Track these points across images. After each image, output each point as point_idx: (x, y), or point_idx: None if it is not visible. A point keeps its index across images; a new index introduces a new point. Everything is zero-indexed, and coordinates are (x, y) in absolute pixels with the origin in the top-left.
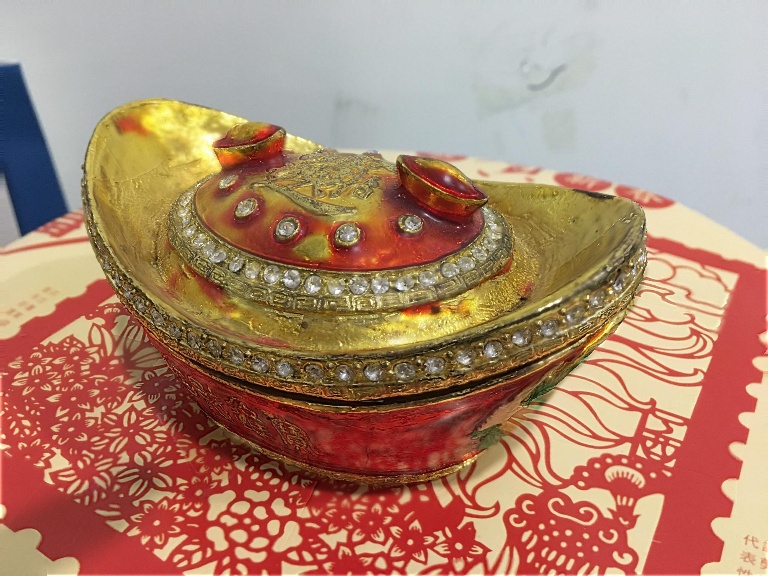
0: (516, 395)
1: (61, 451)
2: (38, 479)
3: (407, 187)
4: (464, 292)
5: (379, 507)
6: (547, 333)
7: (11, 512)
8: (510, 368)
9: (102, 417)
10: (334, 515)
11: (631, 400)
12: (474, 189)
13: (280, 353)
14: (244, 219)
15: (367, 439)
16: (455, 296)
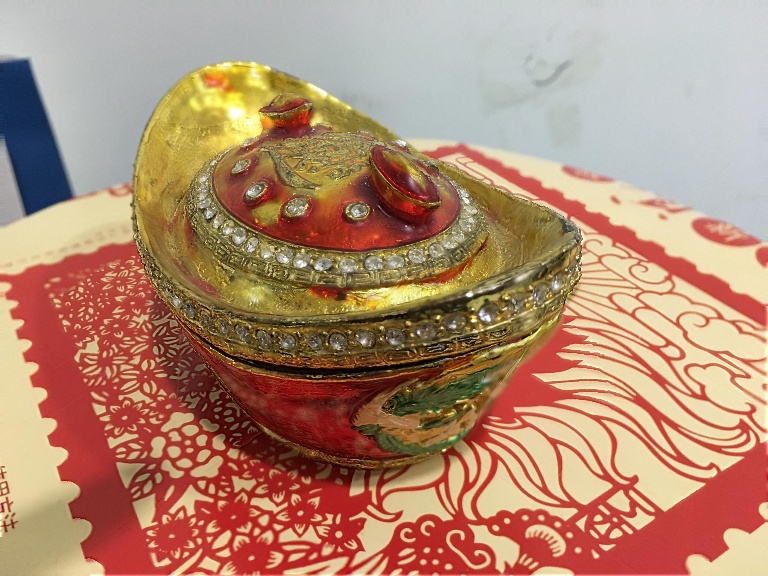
0: (373, 398)
1: (99, 340)
2: (71, 355)
3: (373, 176)
4: (377, 288)
5: (296, 473)
6: (394, 342)
7: (40, 372)
8: (358, 367)
9: (143, 324)
10: (255, 465)
11: (611, 469)
12: (427, 191)
13: (186, 294)
14: (234, 176)
15: (258, 398)
16: (366, 289)
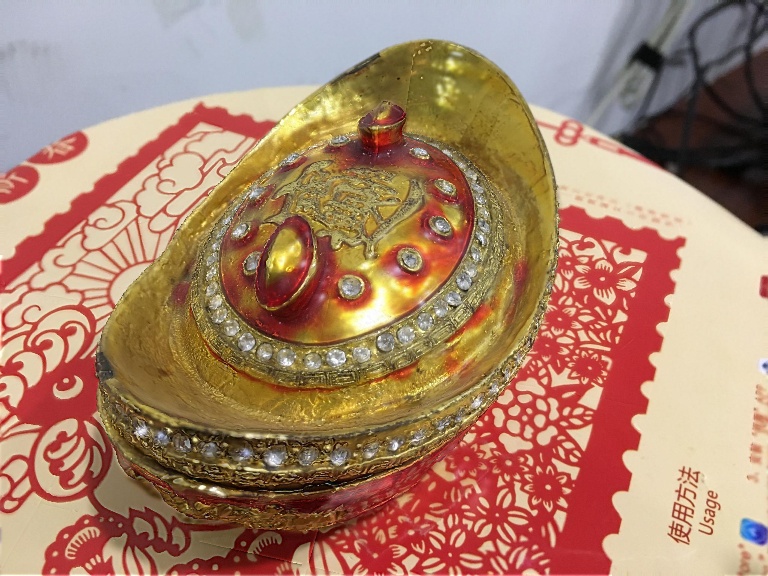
0: None
1: None
2: None
3: None
4: None
5: None
6: None
7: None
8: None
9: None
10: None
11: None
12: None
13: None
14: (423, 263)
15: None
16: None
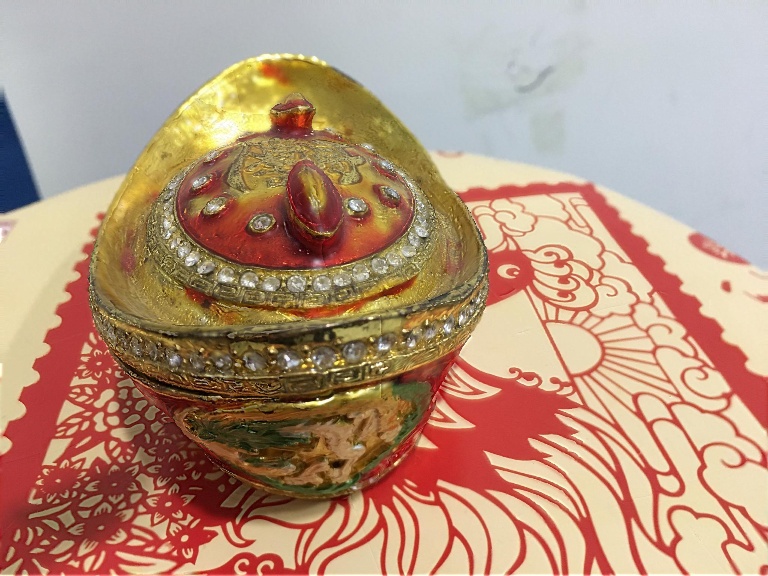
0: None
1: None
2: None
3: None
4: (240, 305)
5: (192, 465)
6: (172, 363)
7: (69, 303)
8: (154, 377)
9: None
10: (165, 444)
11: None
12: (320, 218)
13: None
14: (204, 164)
15: None
16: (229, 303)
